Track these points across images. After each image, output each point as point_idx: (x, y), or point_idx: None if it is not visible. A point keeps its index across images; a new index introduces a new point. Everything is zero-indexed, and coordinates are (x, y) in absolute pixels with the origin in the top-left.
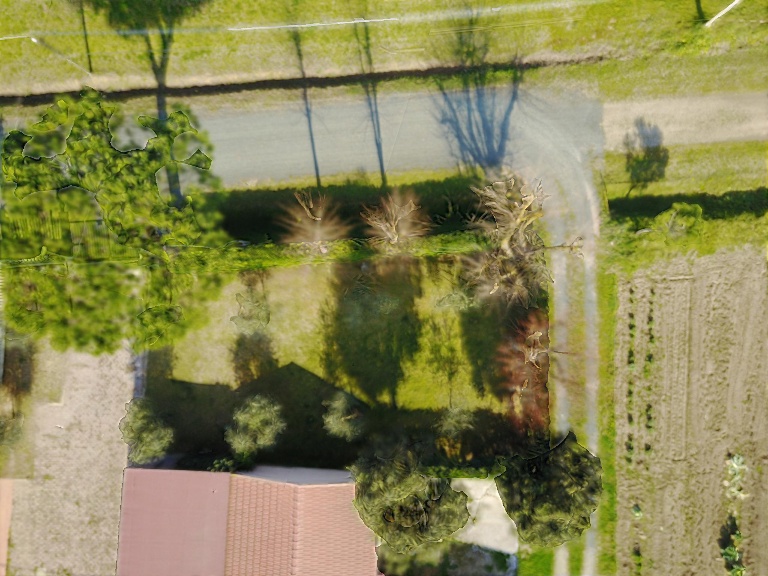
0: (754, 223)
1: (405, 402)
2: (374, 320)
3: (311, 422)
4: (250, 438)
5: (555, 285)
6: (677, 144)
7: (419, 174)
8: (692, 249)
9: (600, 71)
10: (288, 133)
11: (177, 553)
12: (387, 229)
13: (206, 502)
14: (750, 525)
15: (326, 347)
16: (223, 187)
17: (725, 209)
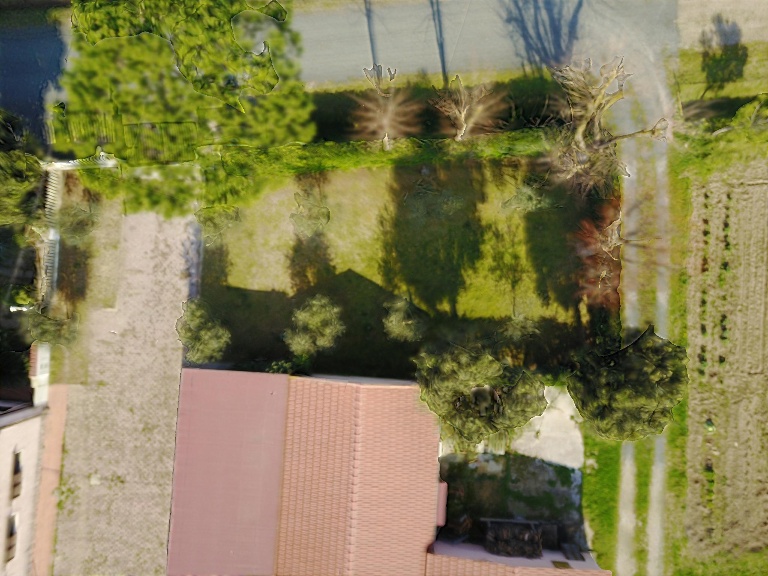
0: None
1: (466, 311)
2: (434, 226)
3: (369, 330)
4: (310, 339)
5: (625, 190)
6: (757, 42)
7: (482, 75)
8: None
9: None
10: (346, 33)
11: (235, 455)
12: (455, 117)
13: (264, 404)
14: None
15: (385, 254)
16: (279, 89)
17: None
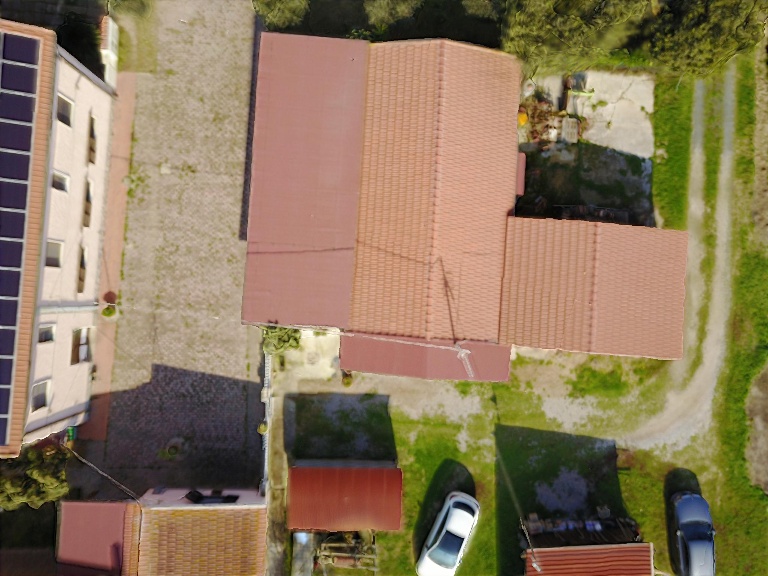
0: None
1: None
2: None
3: (442, 22)
4: (391, 4)
5: None
6: None
7: None
8: None
9: None
10: None
11: (315, 120)
12: None
13: (345, 69)
14: None
15: None
16: None
17: None
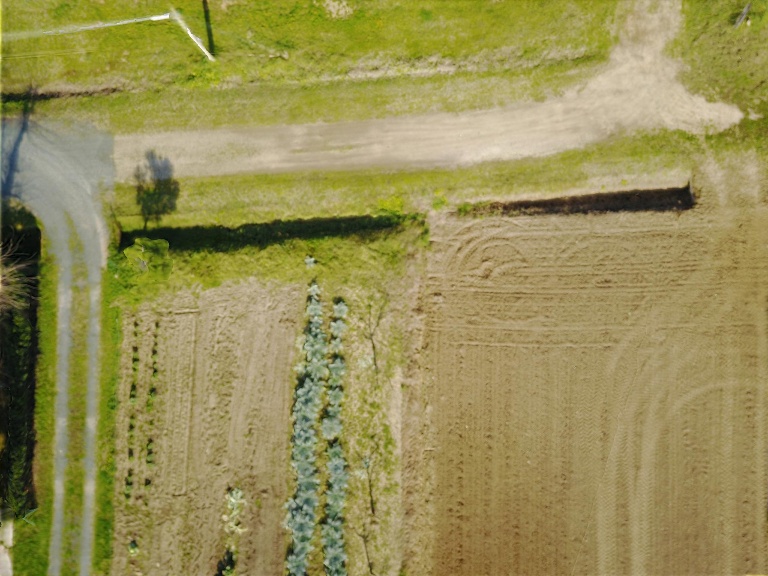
0: (257, 257)
1: None
2: None
3: None
4: None
5: (59, 319)
6: (188, 177)
7: None
8: (196, 282)
9: (112, 103)
10: None
11: None
12: None
13: None
14: (247, 560)
15: None
16: None
17: (232, 242)
